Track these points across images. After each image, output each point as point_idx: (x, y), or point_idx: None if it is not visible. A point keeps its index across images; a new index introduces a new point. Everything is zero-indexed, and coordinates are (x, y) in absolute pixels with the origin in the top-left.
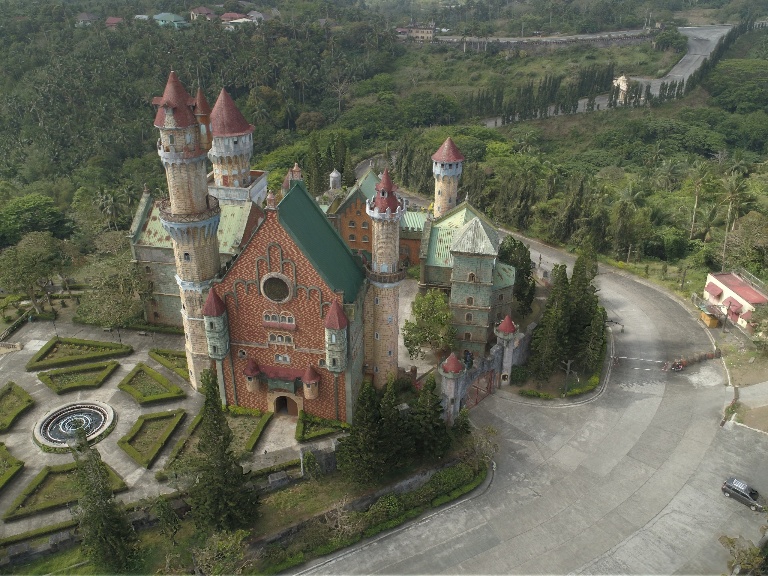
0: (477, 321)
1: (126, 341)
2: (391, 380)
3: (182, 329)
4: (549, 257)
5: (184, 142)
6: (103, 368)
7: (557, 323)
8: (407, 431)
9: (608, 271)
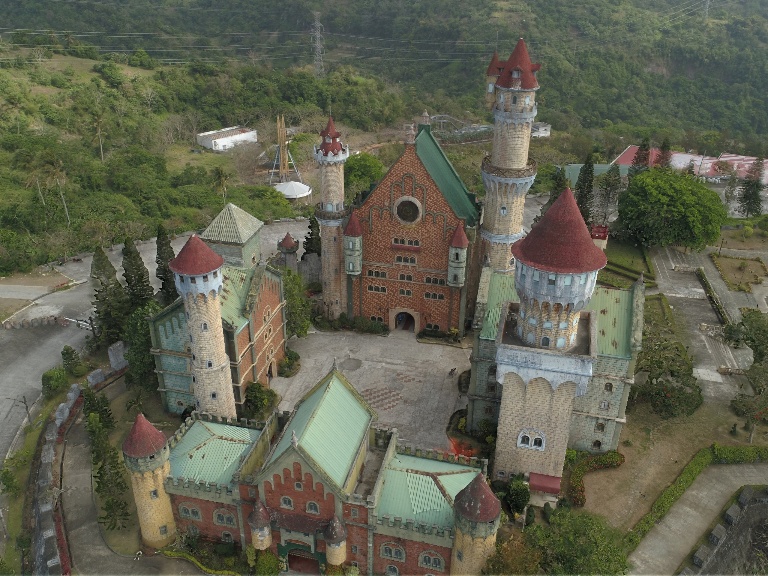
0: None
1: None
2: None
3: None
4: None
5: None
6: None
7: None
8: None
9: None
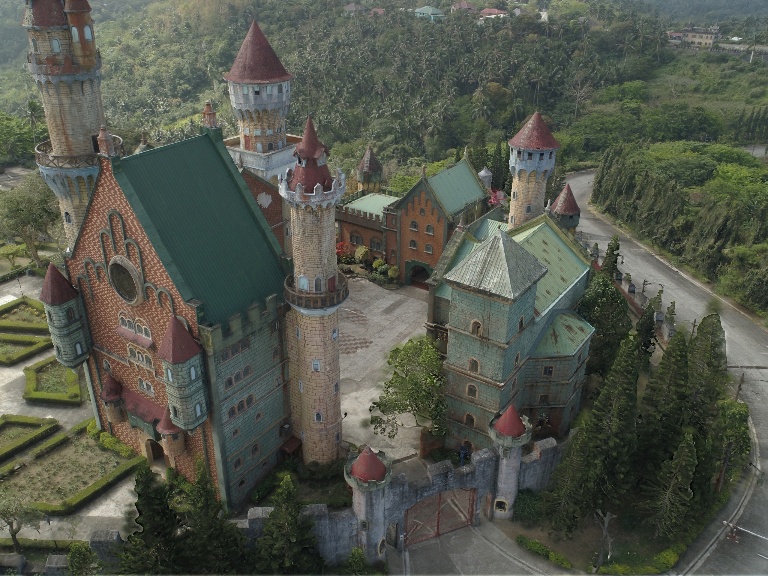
0: (483, 400)
1: None
2: (197, 469)
3: None
4: (731, 327)
5: (50, 51)
6: (35, 344)
7: (607, 439)
8: (246, 557)
9: None
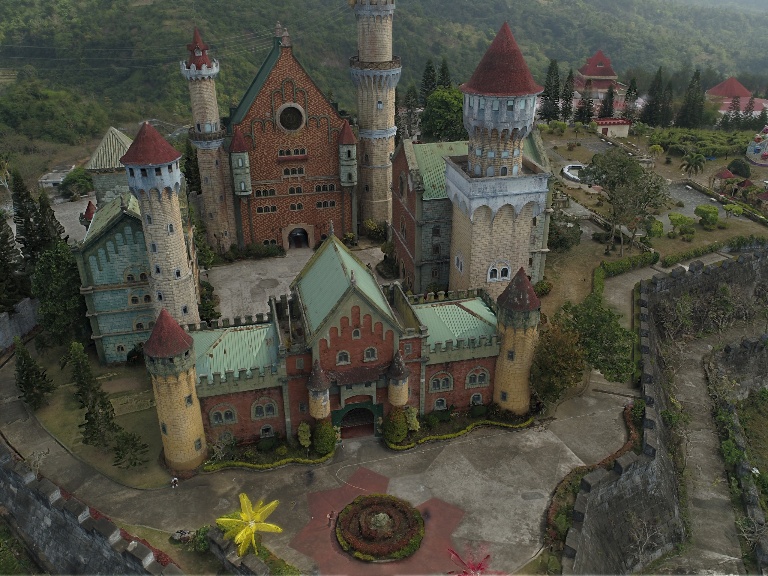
0: None
1: None
2: None
3: None
4: None
5: None
6: None
7: None
8: None
9: None
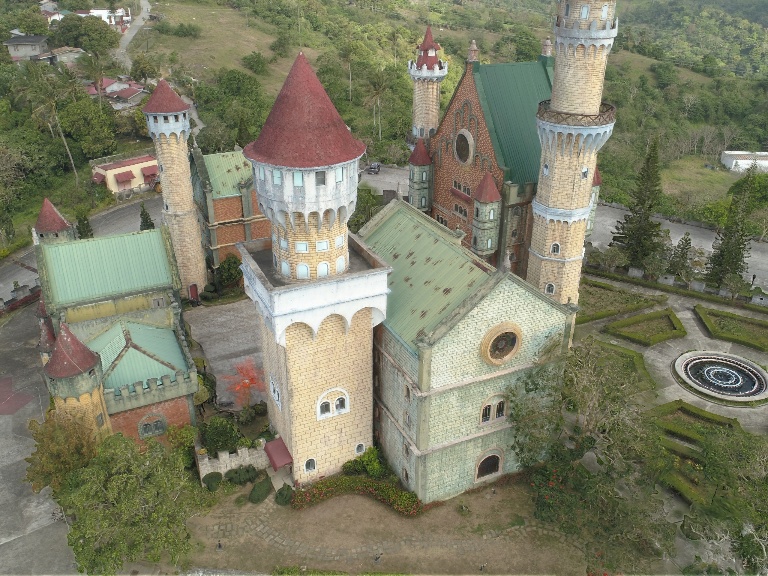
0: None
1: None
2: None
3: None
4: None
5: None
6: None
7: None
8: None
9: (11, 265)
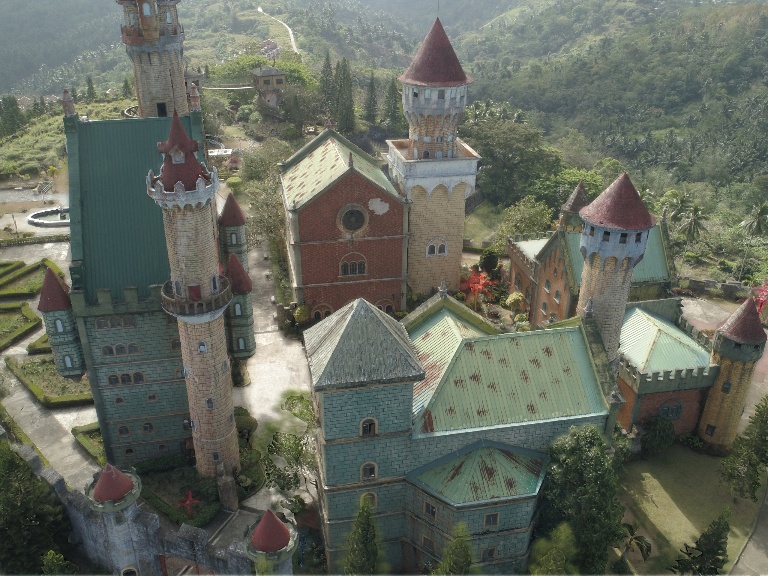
0: None
1: (252, 272)
2: None
3: (288, 290)
4: None
5: (130, 23)
6: None
7: None
8: None
9: None
